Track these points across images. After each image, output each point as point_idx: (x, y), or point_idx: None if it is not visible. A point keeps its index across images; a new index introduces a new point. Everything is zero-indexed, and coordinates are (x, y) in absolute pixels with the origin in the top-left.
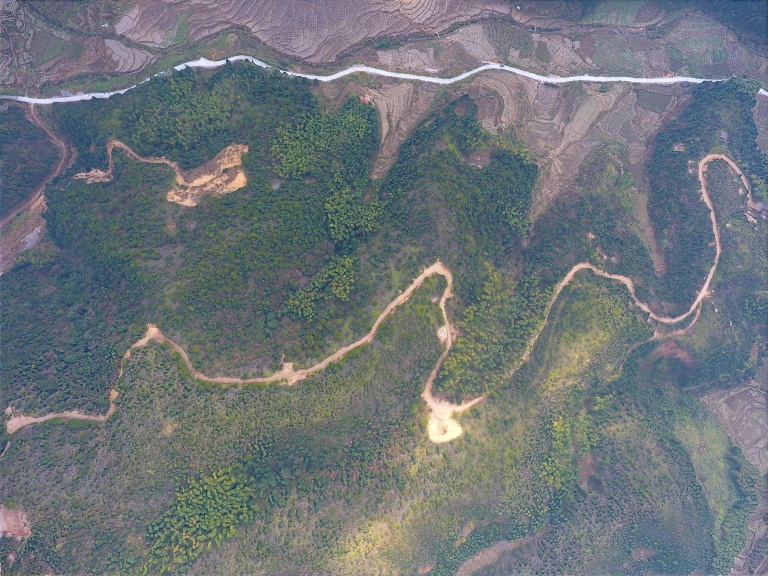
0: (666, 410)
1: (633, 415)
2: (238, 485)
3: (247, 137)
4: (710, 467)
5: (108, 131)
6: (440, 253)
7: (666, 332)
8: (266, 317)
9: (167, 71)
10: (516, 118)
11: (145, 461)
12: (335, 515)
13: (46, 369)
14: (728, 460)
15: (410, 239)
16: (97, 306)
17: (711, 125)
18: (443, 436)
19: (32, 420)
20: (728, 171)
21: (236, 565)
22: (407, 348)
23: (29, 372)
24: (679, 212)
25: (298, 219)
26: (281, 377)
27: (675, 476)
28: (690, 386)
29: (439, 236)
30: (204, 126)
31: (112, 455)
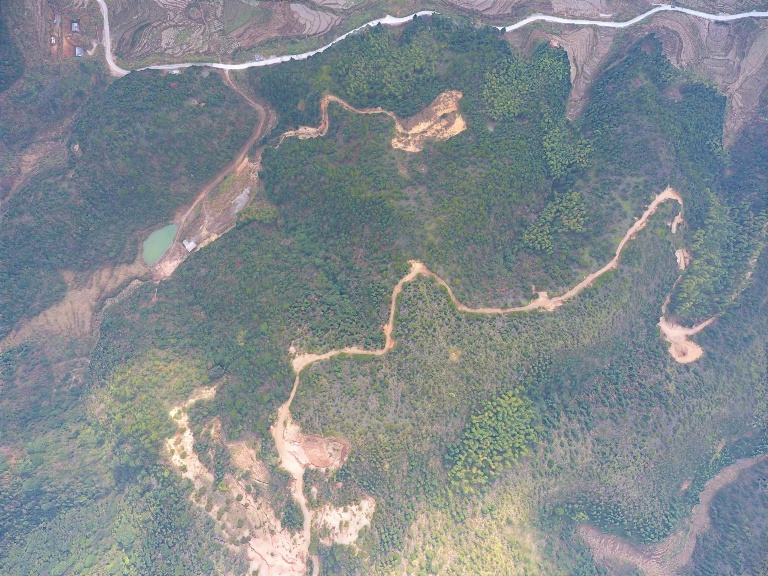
0: None
1: None
2: (521, 407)
3: (461, 82)
4: None
5: (323, 86)
6: (669, 179)
7: None
8: (504, 253)
9: (363, 28)
10: (694, 56)
11: (445, 385)
12: (607, 434)
13: (313, 311)
14: None
15: (629, 171)
16: (340, 252)
17: None
18: (686, 357)
19: (316, 357)
20: None
21: (533, 483)
22: (653, 271)
23: (300, 314)
24: None
25: (525, 156)
26: (537, 305)
27: None
28: None
29: (662, 164)
30: (412, 76)
31: (403, 384)
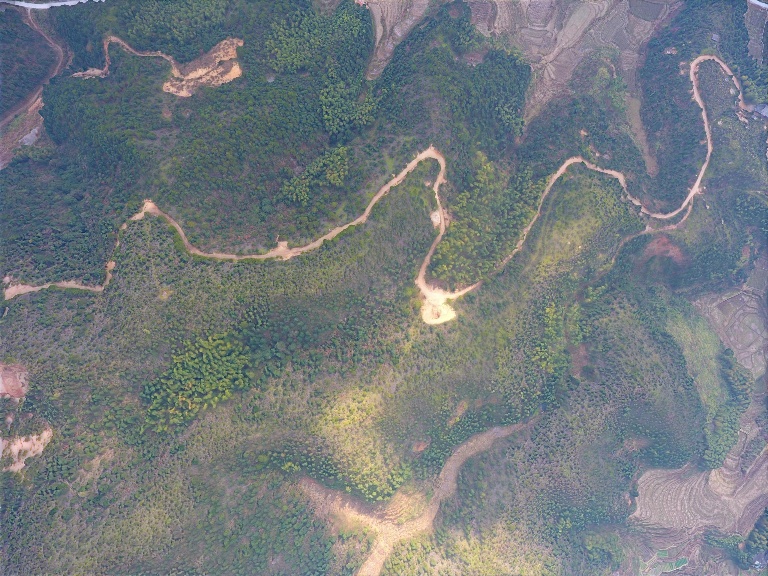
0: (658, 307)
1: (625, 307)
2: (233, 352)
3: (242, 30)
4: (702, 365)
5: (104, 26)
6: (433, 139)
7: (658, 226)
8: (261, 202)
9: None
10: (509, 24)
11: (141, 321)
12: (329, 387)
13: (44, 245)
14: (720, 360)
15: (404, 130)
16: (94, 191)
17: (703, 28)
18: (437, 319)
19: (30, 289)
20: (719, 71)
21: (231, 427)
22: (400, 228)
23: (27, 246)
24: (671, 113)
25: (293, 107)
26: (276, 255)
27: (667, 365)
28: (682, 288)
29: (432, 124)
30: (199, 23)
31: (109, 320)
